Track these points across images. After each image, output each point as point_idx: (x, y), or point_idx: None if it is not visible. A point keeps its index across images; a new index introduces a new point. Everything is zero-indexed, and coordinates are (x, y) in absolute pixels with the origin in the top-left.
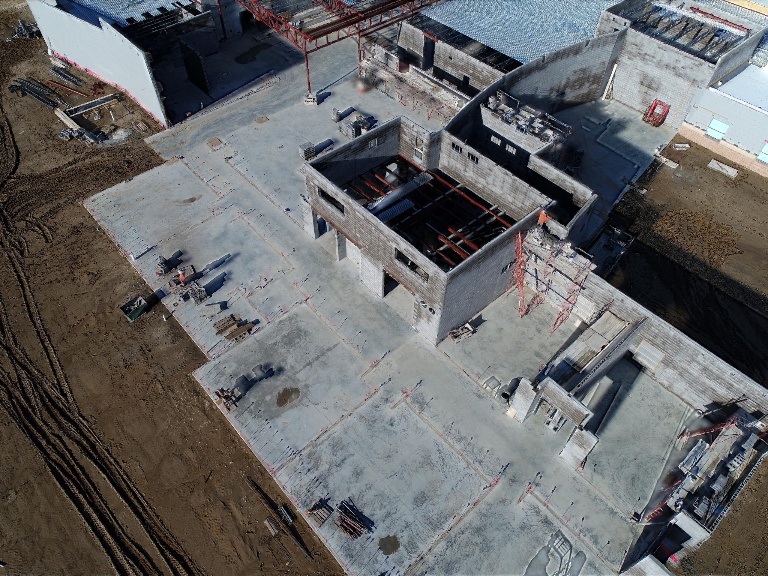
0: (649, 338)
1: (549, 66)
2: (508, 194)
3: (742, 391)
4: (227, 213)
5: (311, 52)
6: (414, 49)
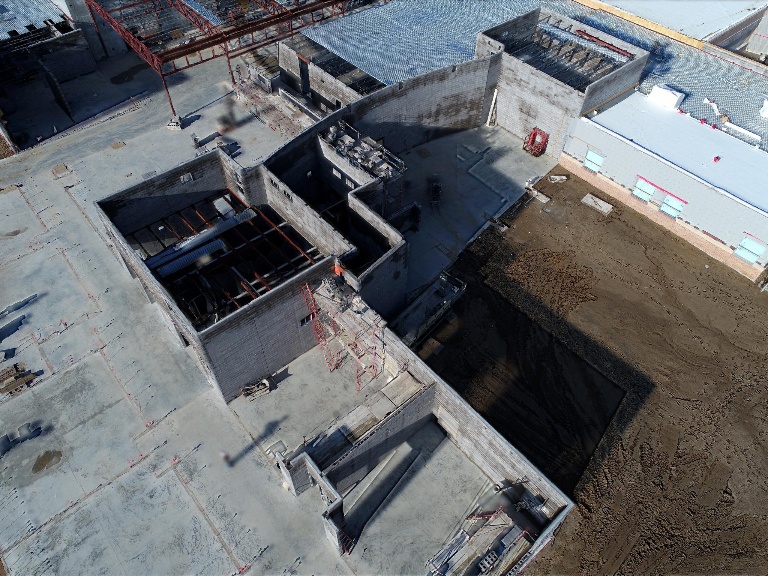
0: (443, 404)
1: (410, 93)
2: (321, 236)
3: (523, 472)
4: (48, 248)
5: (169, 74)
6: (292, 71)
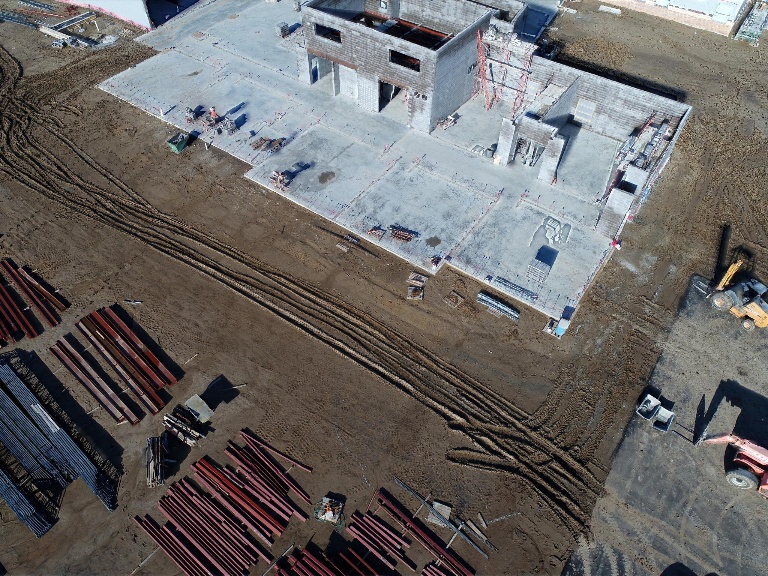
0: (583, 94)
1: None
2: (461, 18)
3: (652, 108)
4: (230, 78)
5: None
6: None
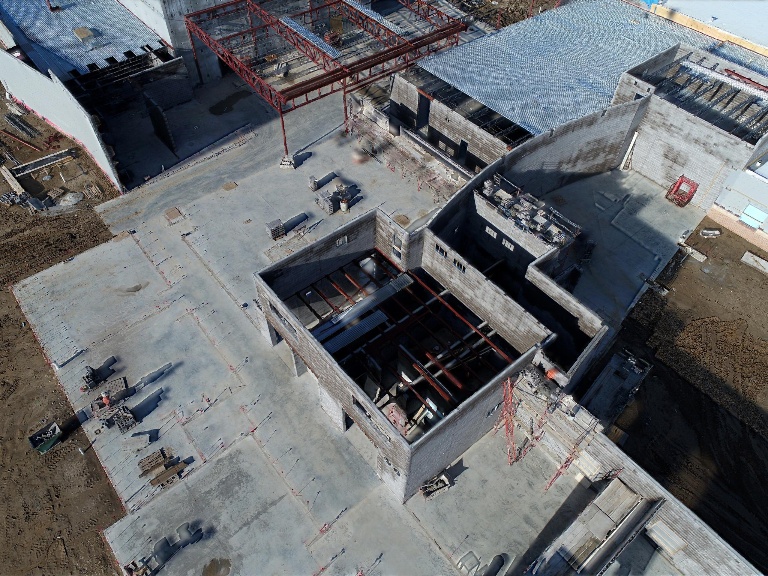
0: (667, 521)
1: (558, 139)
2: (500, 313)
3: None
4: (175, 307)
5: None
6: (408, 105)
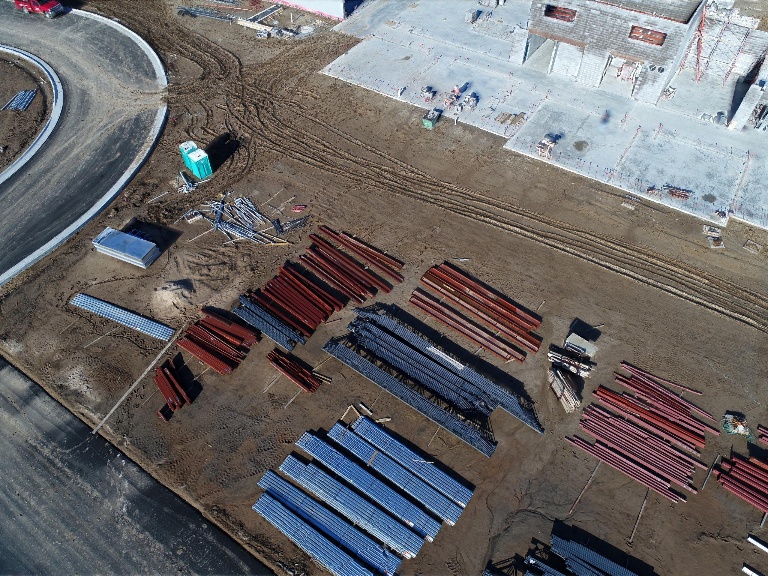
0: None
1: None
2: None
3: None
4: (442, 61)
5: None
6: None
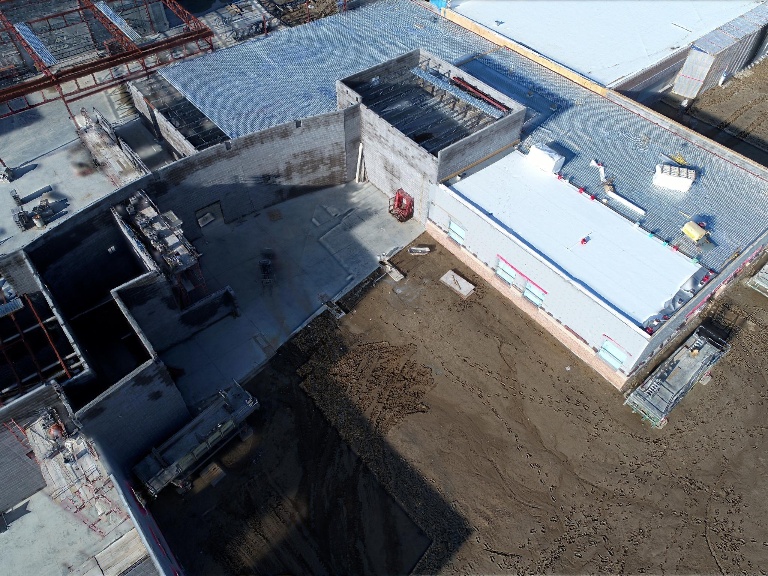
0: None
1: (244, 152)
2: None
3: None
4: None
5: None
6: (146, 114)
